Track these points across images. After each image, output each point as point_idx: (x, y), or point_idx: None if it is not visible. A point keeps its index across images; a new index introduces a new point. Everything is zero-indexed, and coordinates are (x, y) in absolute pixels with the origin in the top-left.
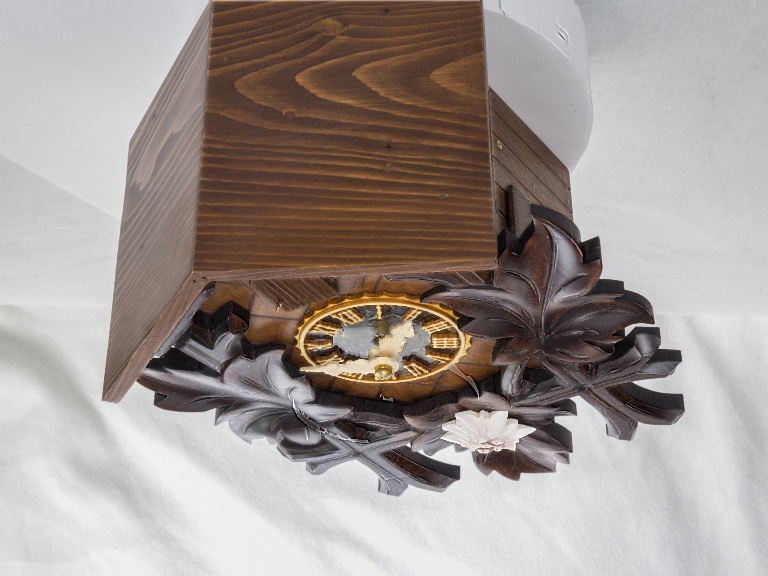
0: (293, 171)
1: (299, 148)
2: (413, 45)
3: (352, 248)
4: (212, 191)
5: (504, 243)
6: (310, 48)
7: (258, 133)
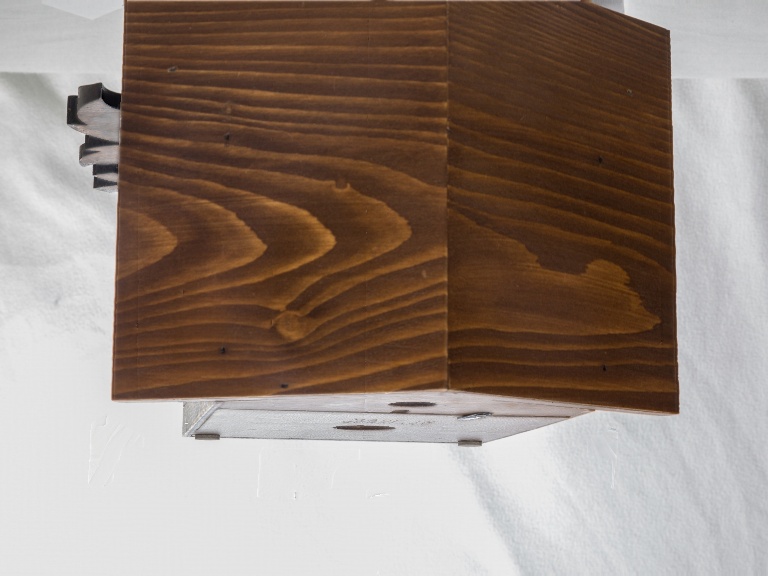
0: (336, 99)
1: (330, 132)
2: (194, 292)
3: None
4: (431, 67)
5: None
6: (317, 290)
7: (379, 154)
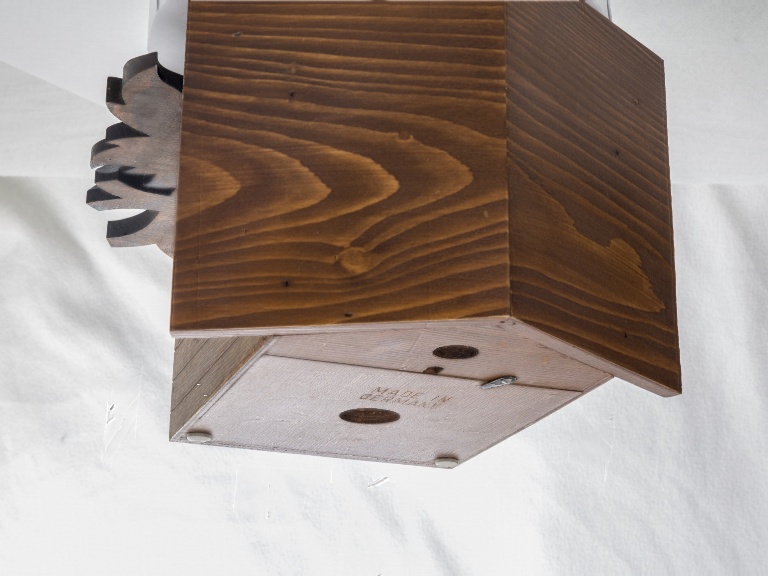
0: (399, 62)
1: (393, 91)
2: (257, 231)
3: None
4: (490, 36)
5: None
6: (381, 228)
7: (441, 110)
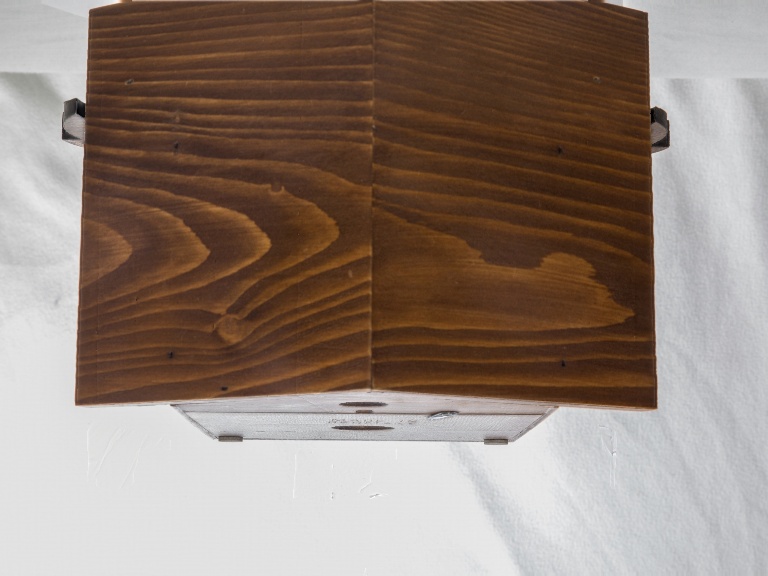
0: (272, 102)
1: (266, 136)
2: (146, 298)
3: (215, 4)
4: (358, 66)
5: None
6: (254, 293)
7: (310, 156)
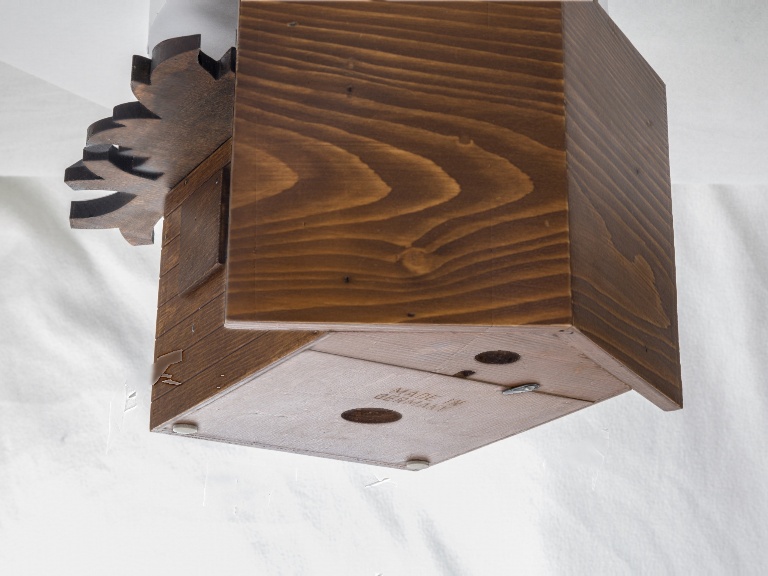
0: (458, 66)
1: (452, 94)
2: (316, 225)
3: None
4: (548, 49)
5: (233, 54)
6: (443, 231)
7: (501, 118)
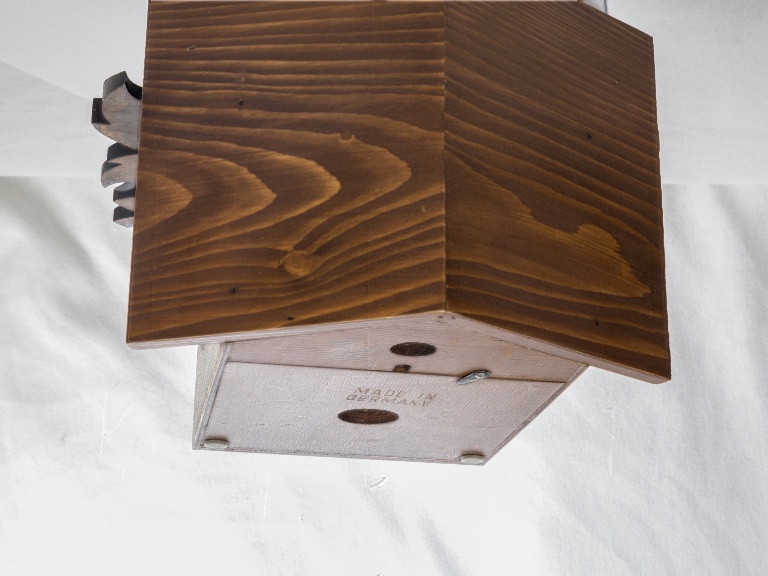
0: (342, 62)
1: (336, 92)
2: (207, 240)
3: None
4: (429, 29)
5: None
6: (323, 230)
7: (381, 108)
